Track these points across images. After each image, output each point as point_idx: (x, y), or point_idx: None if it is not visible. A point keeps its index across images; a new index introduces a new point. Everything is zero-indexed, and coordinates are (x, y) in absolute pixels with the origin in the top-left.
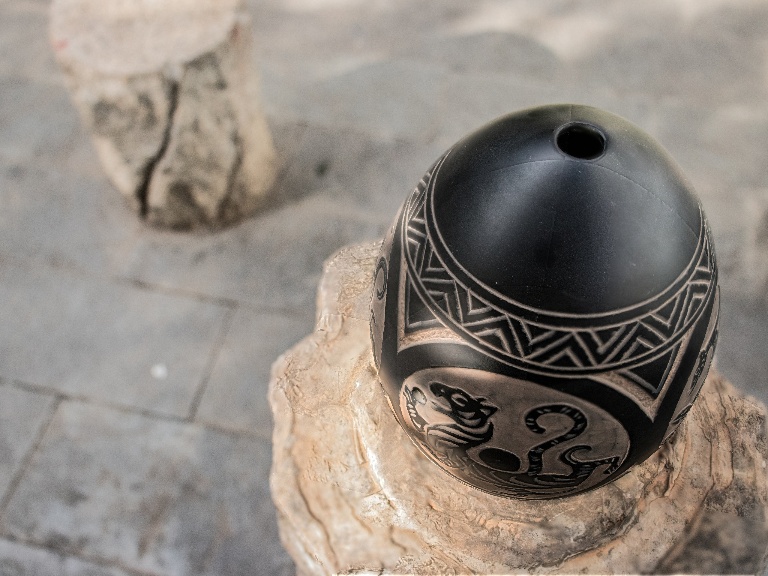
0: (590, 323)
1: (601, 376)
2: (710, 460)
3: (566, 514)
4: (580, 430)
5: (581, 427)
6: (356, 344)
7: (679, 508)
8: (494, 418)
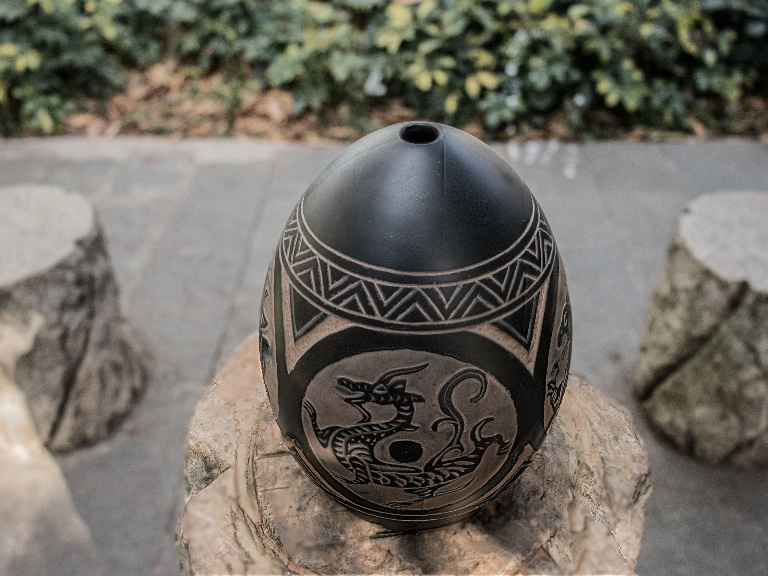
0: None
1: None
2: None
3: None
4: None
5: None
6: None
7: None
8: None
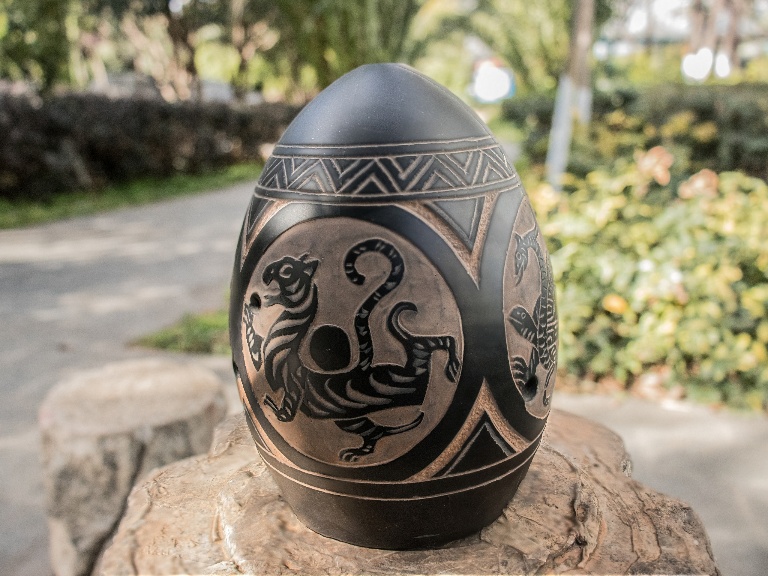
0: (389, 151)
1: (408, 206)
2: (631, 539)
3: (453, 571)
4: (399, 276)
5: (399, 271)
6: (239, 461)
7: None
8: (317, 278)
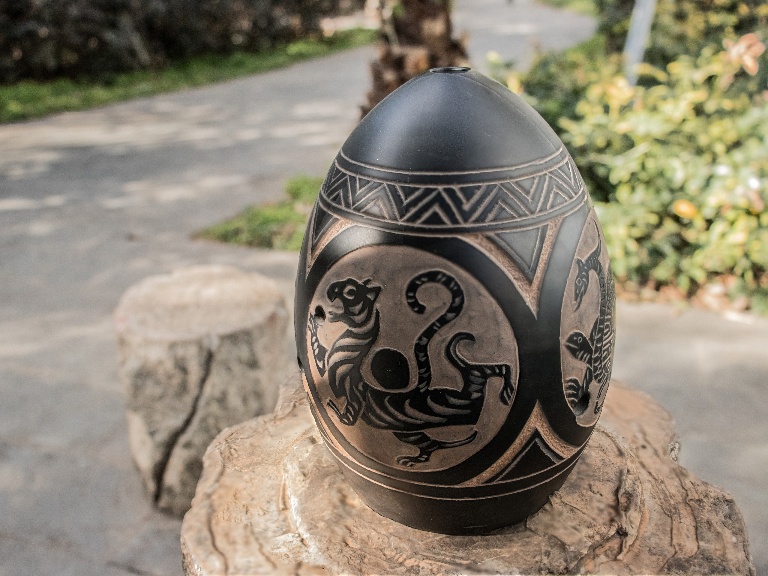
0: (453, 180)
1: (470, 238)
2: (671, 532)
3: (498, 559)
4: (459, 307)
5: (459, 303)
6: (303, 423)
7: (635, 572)
8: (379, 303)
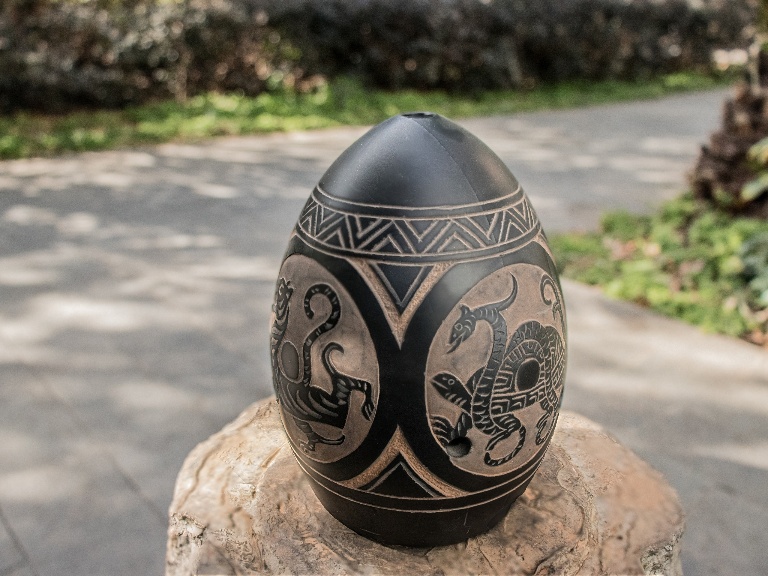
0: (358, 210)
1: (356, 263)
2: None
3: (379, 569)
4: (335, 320)
5: (336, 316)
6: None
7: None
8: (291, 302)
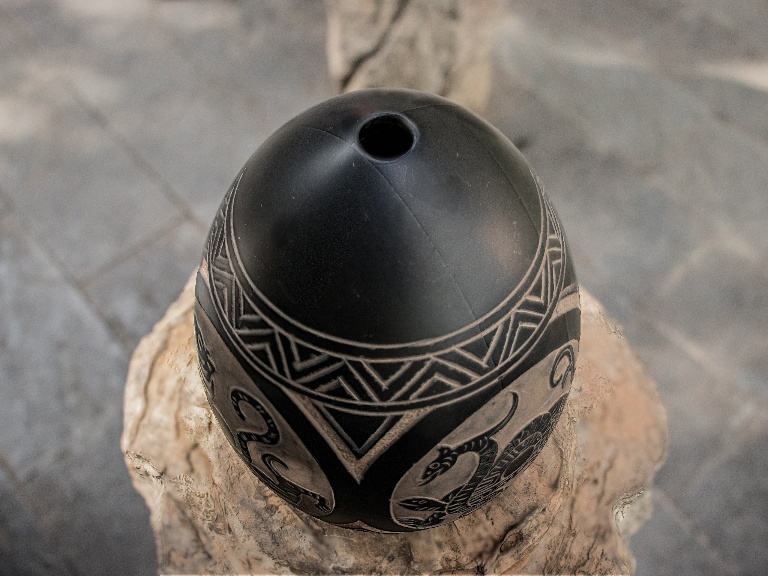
0: (292, 330)
1: (296, 395)
2: None
3: (345, 540)
4: (274, 440)
5: (274, 437)
6: None
7: None
8: (215, 378)
